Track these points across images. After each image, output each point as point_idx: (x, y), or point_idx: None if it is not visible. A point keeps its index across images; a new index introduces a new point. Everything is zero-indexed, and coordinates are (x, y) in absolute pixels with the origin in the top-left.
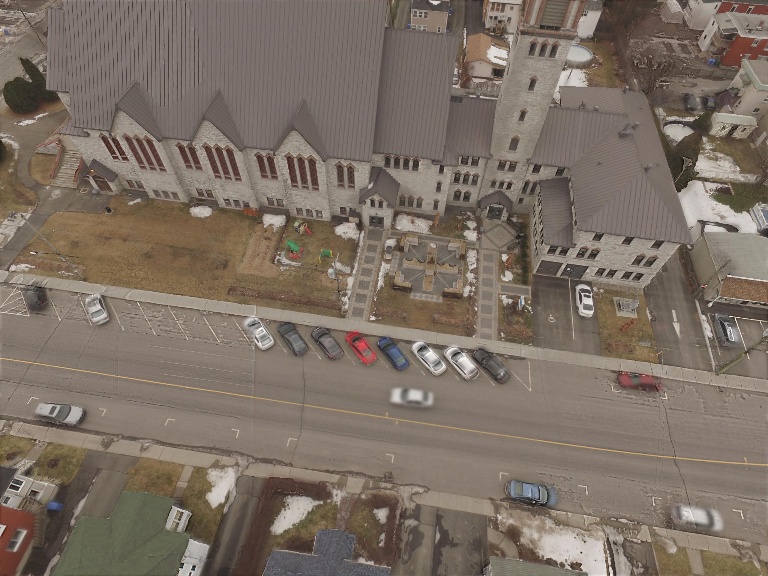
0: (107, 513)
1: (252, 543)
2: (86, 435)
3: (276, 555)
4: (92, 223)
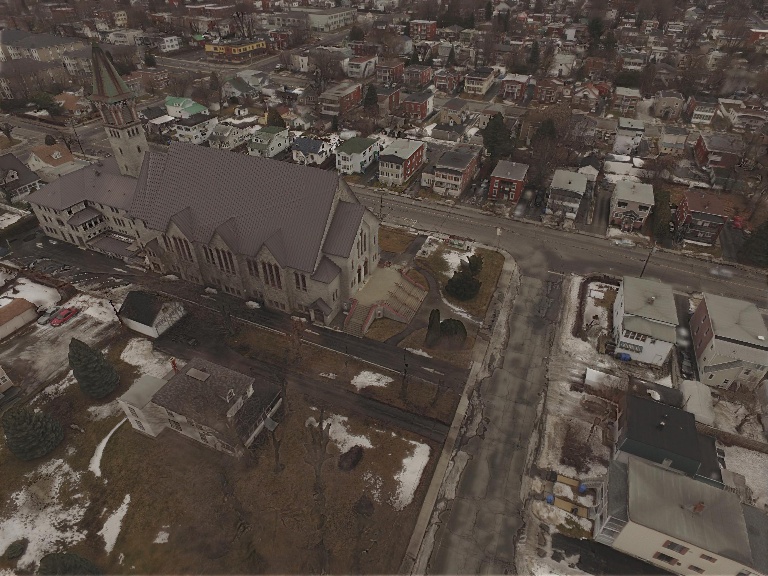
0: (364, 176)
1: (324, 162)
2: (373, 189)
3: (316, 153)
4: (380, 245)
